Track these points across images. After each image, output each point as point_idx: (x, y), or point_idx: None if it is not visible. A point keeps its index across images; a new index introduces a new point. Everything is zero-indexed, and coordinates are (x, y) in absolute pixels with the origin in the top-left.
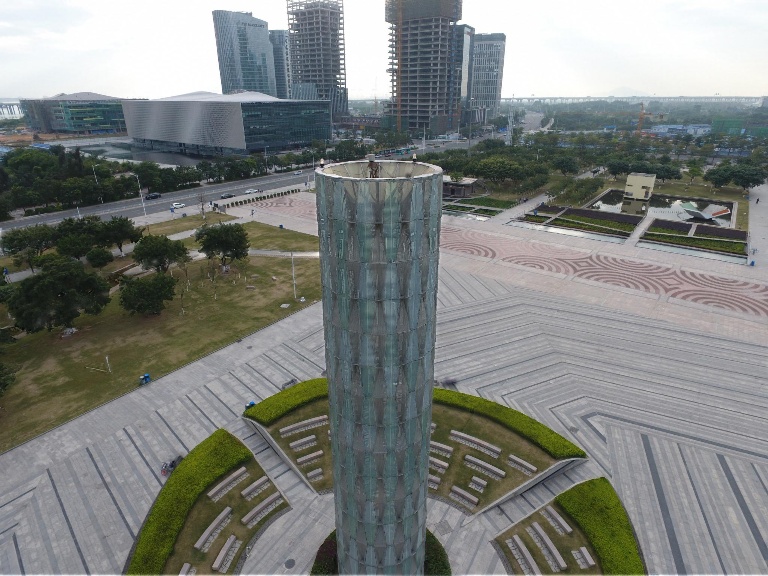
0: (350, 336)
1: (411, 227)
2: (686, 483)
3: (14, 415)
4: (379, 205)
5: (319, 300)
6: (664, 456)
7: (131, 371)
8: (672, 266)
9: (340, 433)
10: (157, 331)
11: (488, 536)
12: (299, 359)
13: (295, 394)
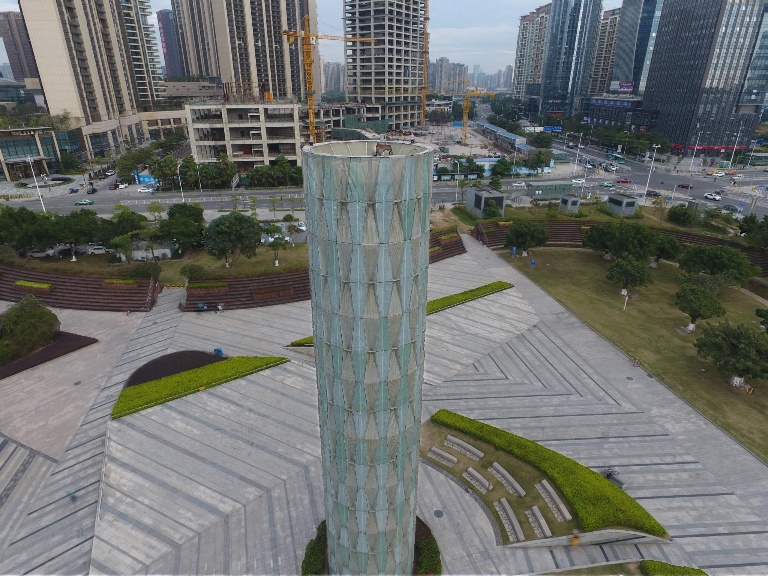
0: None
1: None
2: None
3: (739, 400)
4: None
5: None
6: None
7: None
8: None
9: None
10: None
11: None
12: None
13: None
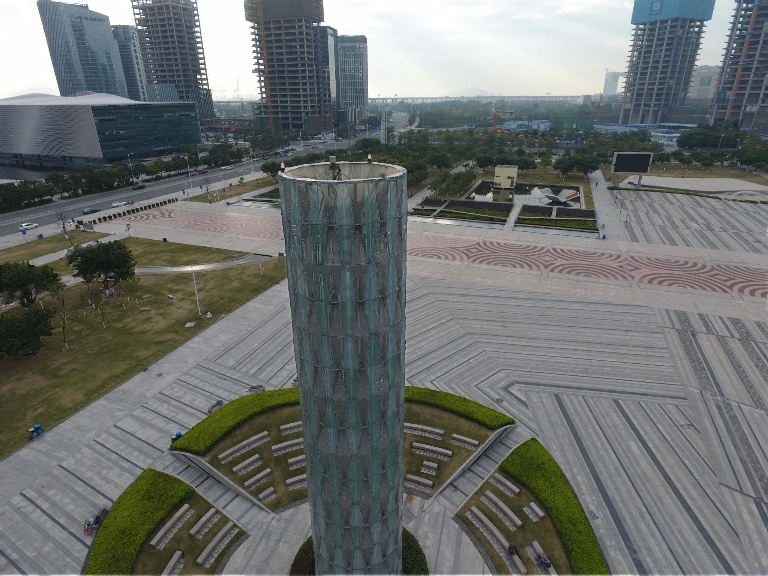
0: (331, 341)
1: (388, 226)
2: (596, 429)
3: None
4: (358, 206)
5: (227, 314)
6: (575, 409)
7: (14, 425)
8: (545, 245)
9: (321, 442)
10: (37, 373)
11: (449, 514)
12: (220, 378)
13: (226, 416)
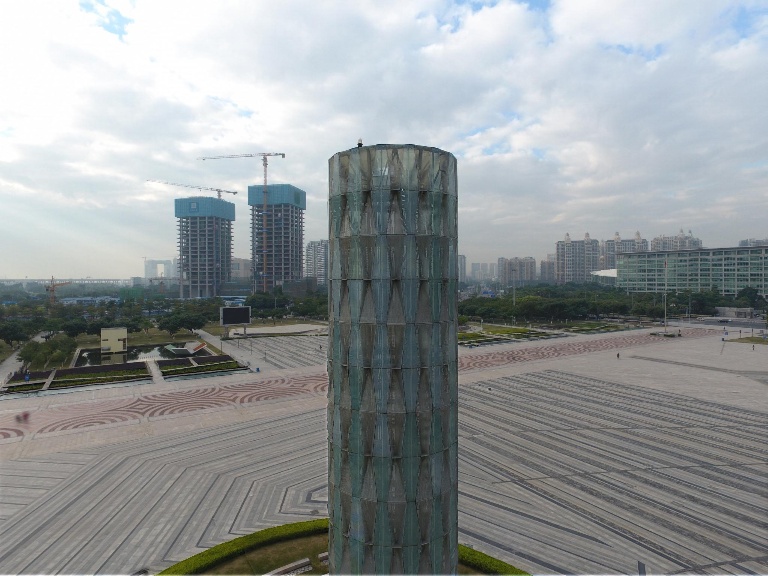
0: (440, 329)
1: None
2: None
3: None
4: None
5: None
6: None
7: None
8: (213, 386)
9: (421, 489)
10: None
11: None
12: None
13: None
